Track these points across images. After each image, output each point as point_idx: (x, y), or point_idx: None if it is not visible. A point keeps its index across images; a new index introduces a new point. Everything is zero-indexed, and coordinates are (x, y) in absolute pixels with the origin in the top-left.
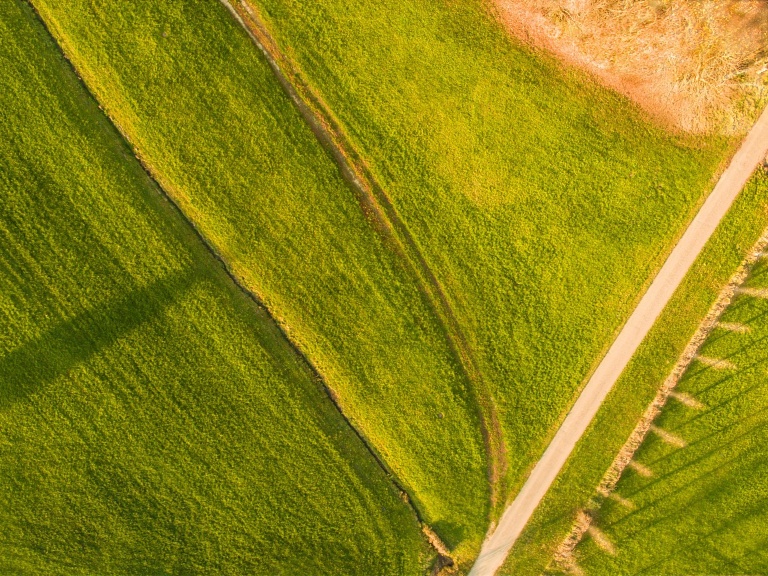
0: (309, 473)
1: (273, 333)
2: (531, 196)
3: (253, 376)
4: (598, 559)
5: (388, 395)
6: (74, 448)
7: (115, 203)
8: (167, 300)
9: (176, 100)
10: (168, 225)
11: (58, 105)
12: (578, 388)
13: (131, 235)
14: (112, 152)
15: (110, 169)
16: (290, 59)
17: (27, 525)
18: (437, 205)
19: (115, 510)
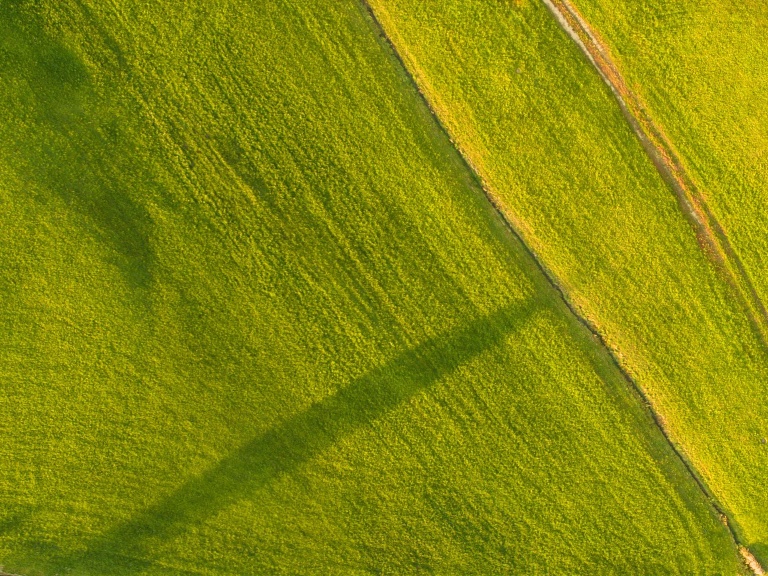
0: (635, 497)
1: (606, 360)
2: None
3: (586, 402)
4: None
5: (714, 421)
6: (412, 472)
7: (462, 234)
8: (507, 328)
9: (526, 134)
10: (512, 255)
11: (412, 138)
12: None
13: (476, 265)
14: (461, 184)
15: (459, 201)
16: (636, 95)
17: (364, 548)
18: None
19: (449, 533)
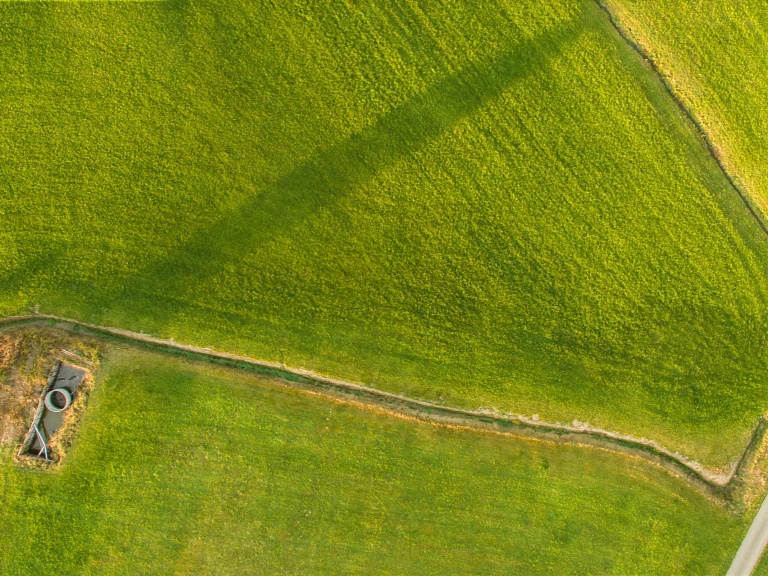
0: (692, 234)
1: (658, 87)
2: None
3: (638, 132)
4: None
5: None
6: (456, 208)
7: None
8: (553, 53)
9: None
10: None
11: None
12: None
13: None
14: None
15: None
16: None
17: (407, 288)
18: None
19: (496, 273)
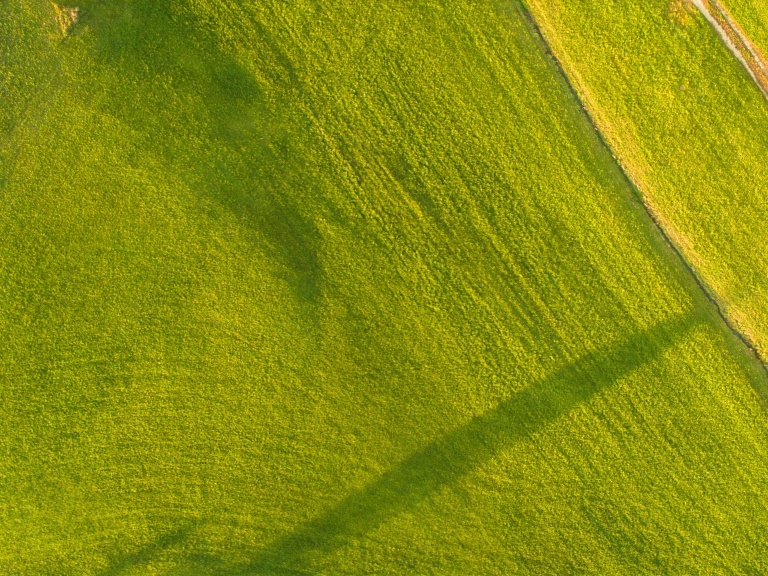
0: None
1: (761, 374)
2: None
3: (741, 415)
4: None
5: None
6: (570, 485)
7: (623, 249)
8: (665, 342)
9: (688, 151)
10: (671, 270)
11: (576, 155)
12: None
13: (636, 280)
14: (624, 200)
15: (621, 216)
16: None
17: (521, 560)
18: None
19: (605, 545)
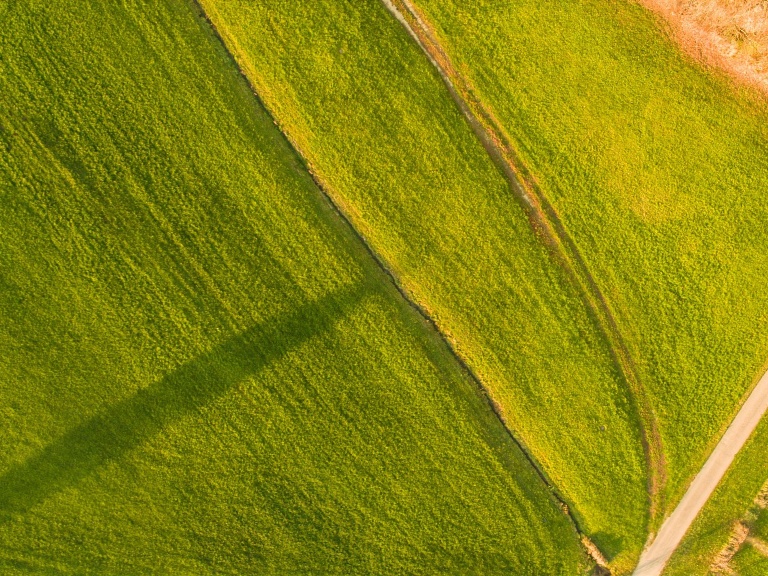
0: (472, 485)
1: (440, 346)
2: (698, 212)
3: (419, 389)
4: (753, 570)
5: (552, 408)
6: (242, 460)
7: (288, 218)
8: (337, 314)
9: (351, 116)
10: (339, 239)
11: (234, 120)
12: (739, 401)
13: (303, 249)
14: (286, 167)
15: (284, 184)
16: (464, 76)
17: (194, 536)
18: (605, 220)
19: (281, 522)
